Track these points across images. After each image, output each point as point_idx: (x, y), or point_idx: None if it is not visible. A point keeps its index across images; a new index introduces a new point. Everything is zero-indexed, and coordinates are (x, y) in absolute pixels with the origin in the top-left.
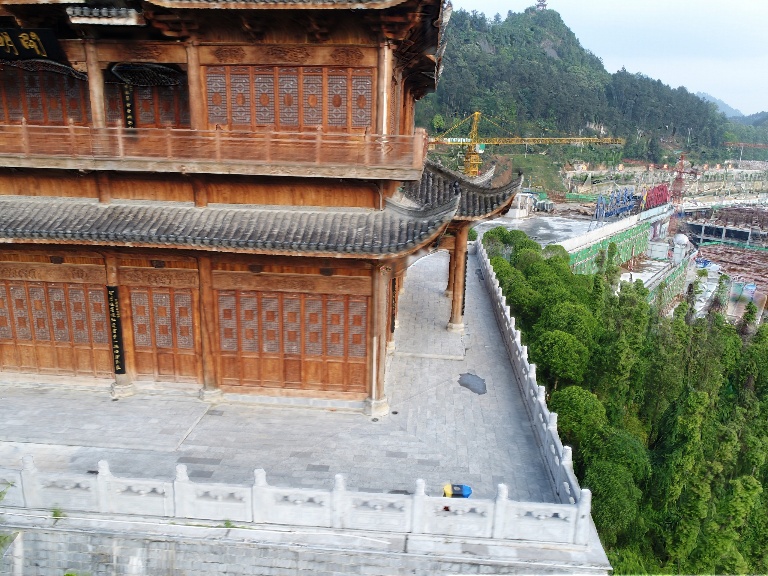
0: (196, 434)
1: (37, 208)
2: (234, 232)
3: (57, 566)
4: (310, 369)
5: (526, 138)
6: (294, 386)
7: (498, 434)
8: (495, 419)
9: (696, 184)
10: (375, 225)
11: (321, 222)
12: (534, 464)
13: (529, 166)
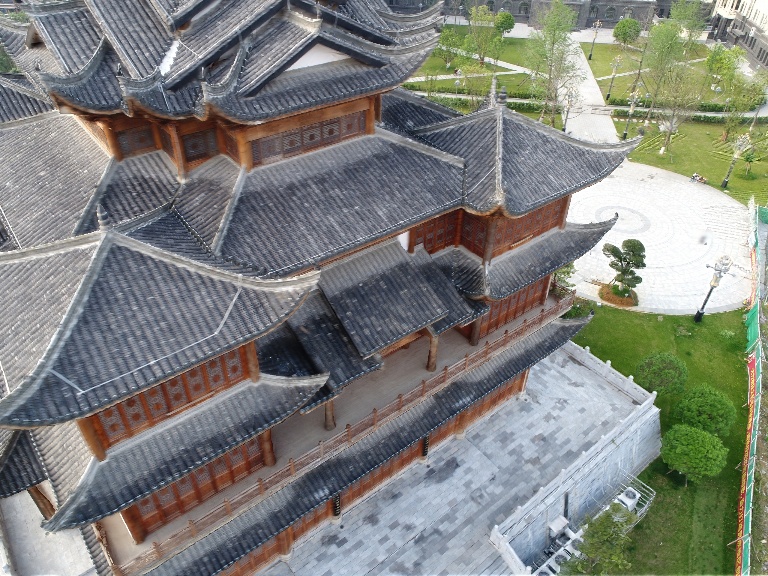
0: None
1: None
2: None
3: None
4: None
5: None
6: None
7: None
8: None
9: None
10: None
11: None
12: None
13: None
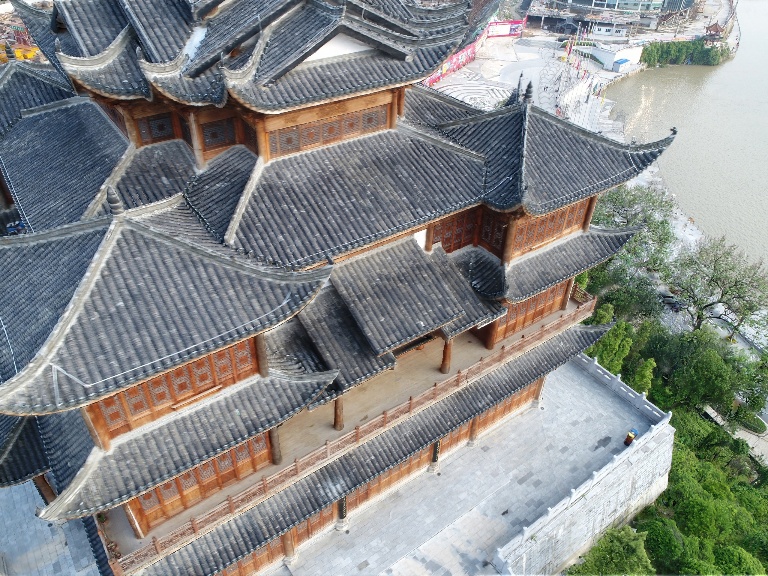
0: (500, 466)
1: (417, 416)
2: (520, 375)
3: (536, 553)
4: (514, 403)
5: None
6: (506, 414)
7: (586, 386)
8: (574, 377)
9: None
10: (565, 338)
11: (544, 347)
12: (614, 396)
13: None
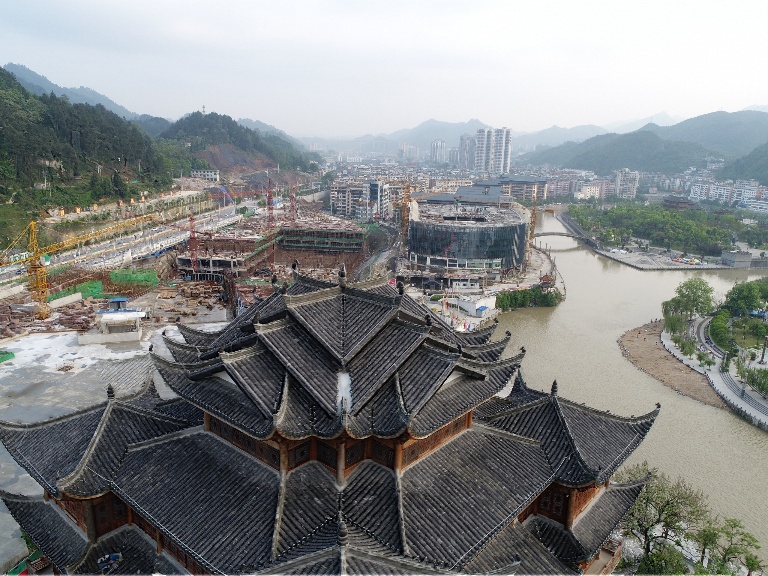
0: None
1: None
2: None
3: None
4: None
5: (80, 236)
6: None
7: None
8: None
9: (162, 213)
10: None
11: None
12: None
13: (1, 220)
